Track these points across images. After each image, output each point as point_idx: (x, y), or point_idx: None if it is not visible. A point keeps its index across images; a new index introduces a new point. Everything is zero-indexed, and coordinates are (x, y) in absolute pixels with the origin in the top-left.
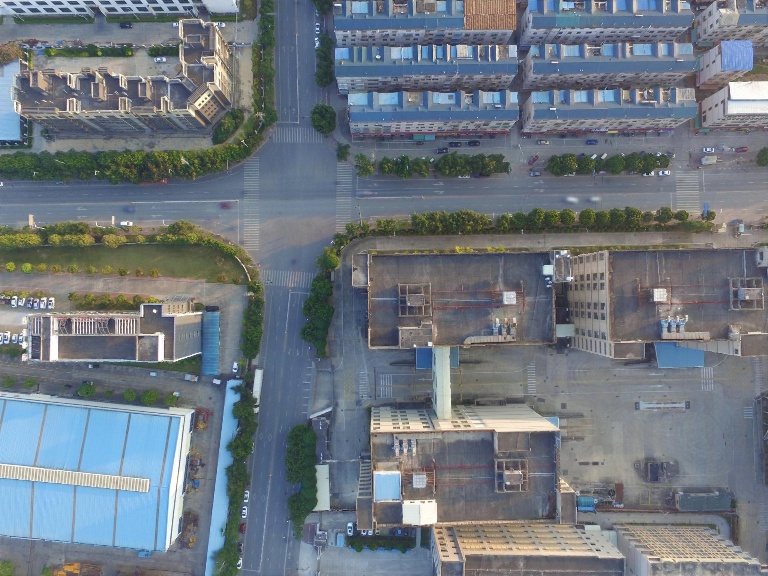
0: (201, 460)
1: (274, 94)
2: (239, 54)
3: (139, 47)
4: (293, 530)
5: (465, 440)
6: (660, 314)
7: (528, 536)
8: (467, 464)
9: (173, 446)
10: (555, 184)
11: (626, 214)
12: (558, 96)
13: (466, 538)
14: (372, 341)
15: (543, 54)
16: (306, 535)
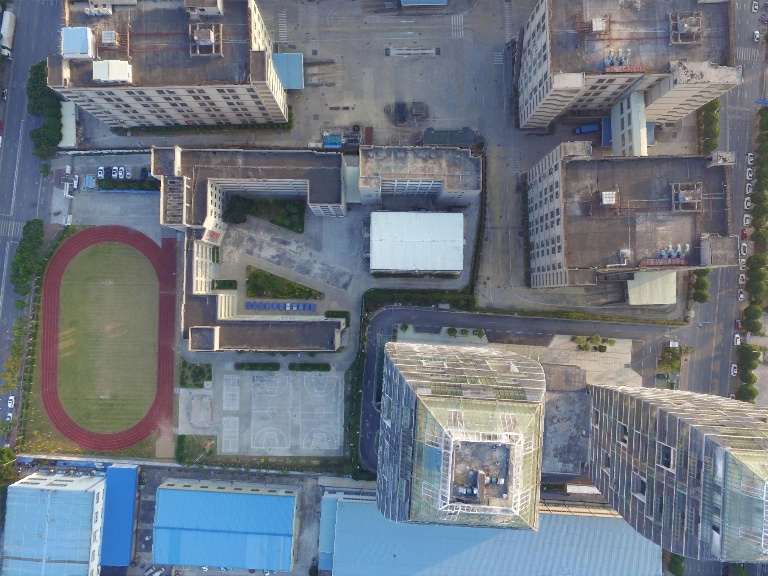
0: None
1: None
2: None
3: None
4: (40, 168)
5: (162, 9)
6: None
7: None
8: (163, 31)
9: None
10: None
11: None
12: None
13: None
14: None
15: None
16: (59, 180)
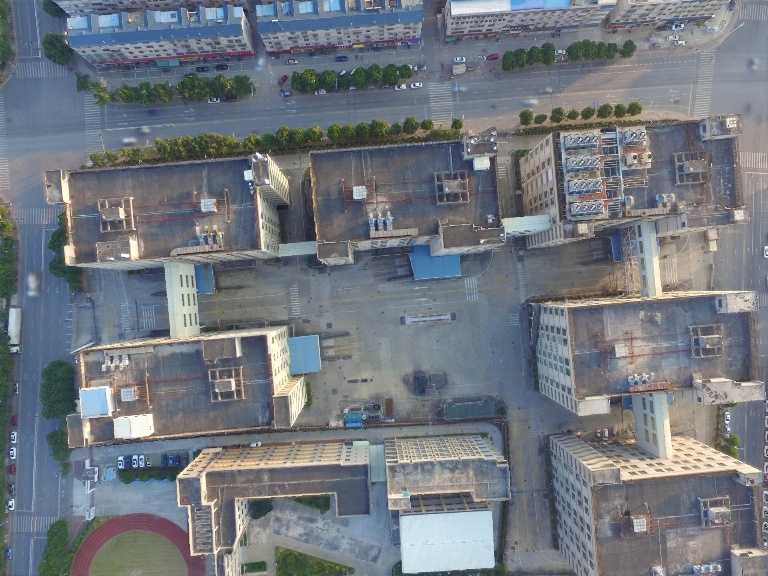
0: None
1: (14, 29)
2: None
3: None
4: (59, 467)
5: (179, 353)
6: (368, 214)
7: (288, 454)
8: (182, 376)
9: None
10: (308, 104)
11: (370, 126)
12: (282, 8)
13: (223, 459)
14: (77, 259)
15: None
16: (78, 472)
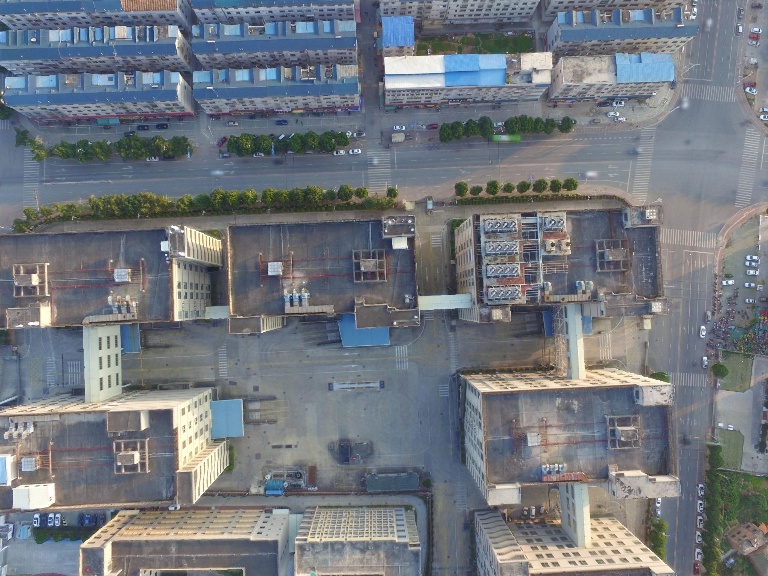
0: None
1: None
2: None
3: None
4: None
5: (86, 421)
6: (284, 288)
7: (203, 521)
8: (87, 446)
9: None
10: (246, 165)
11: (304, 193)
12: (219, 75)
13: (135, 525)
14: None
15: (202, 34)
16: None
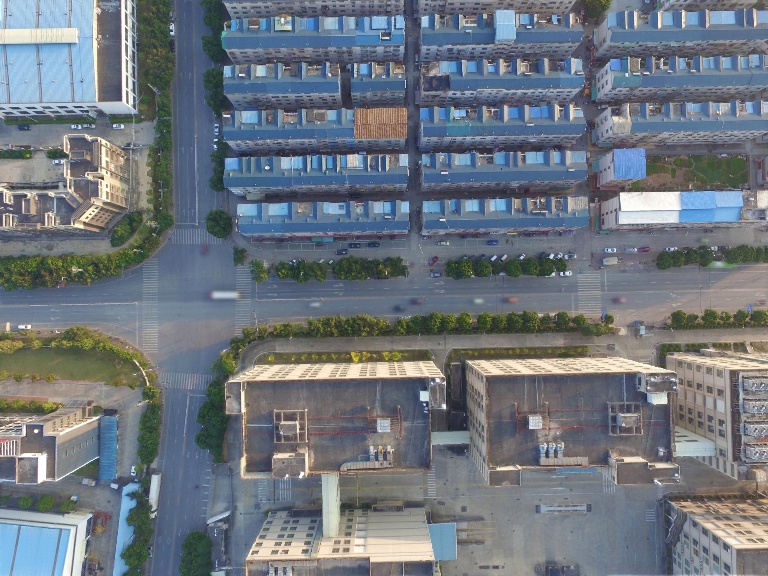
0: (99, 564)
1: (173, 195)
2: (138, 155)
3: (37, 149)
4: None
5: (342, 566)
6: (539, 439)
7: None
8: None
9: (62, 559)
10: (456, 285)
11: (523, 319)
12: (449, 205)
13: None
14: (248, 467)
15: (434, 164)
16: None
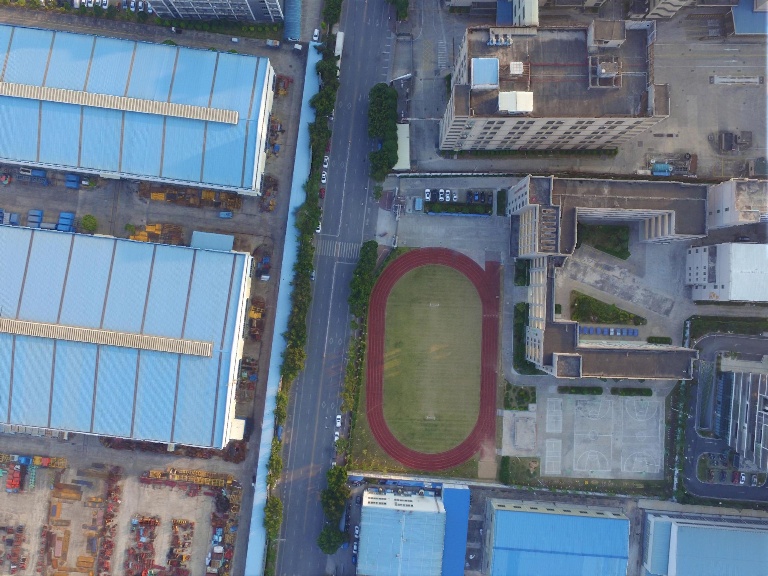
0: (281, 126)
1: None
2: None
3: None
4: (373, 189)
5: (559, 39)
6: None
7: None
8: (561, 62)
9: (261, 83)
10: None
11: None
12: None
13: None
14: None
15: None
16: (384, 202)
